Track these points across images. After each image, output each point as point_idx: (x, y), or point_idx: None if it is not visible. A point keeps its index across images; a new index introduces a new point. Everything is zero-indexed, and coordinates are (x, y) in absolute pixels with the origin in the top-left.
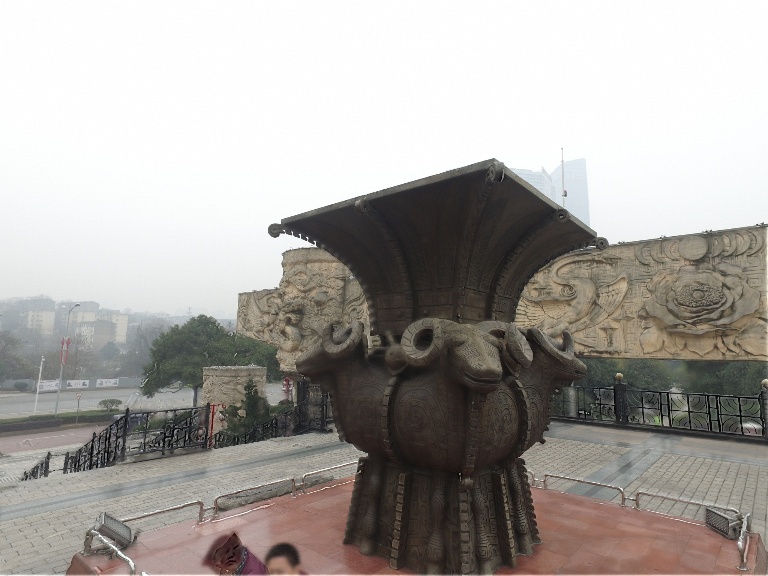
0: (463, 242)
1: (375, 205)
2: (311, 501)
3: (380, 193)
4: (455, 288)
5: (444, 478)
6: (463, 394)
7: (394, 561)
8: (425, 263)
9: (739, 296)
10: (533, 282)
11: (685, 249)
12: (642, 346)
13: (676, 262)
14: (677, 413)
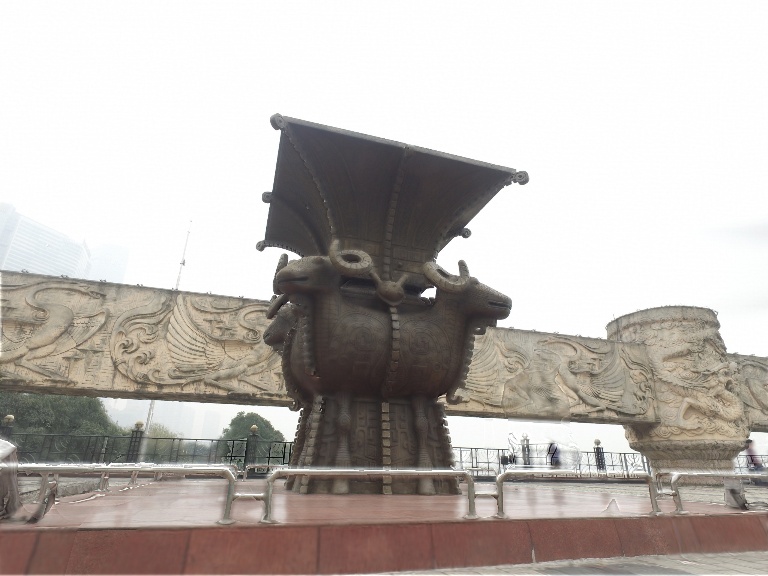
0: (451, 218)
1: (411, 157)
2: (152, 491)
3: (424, 150)
4: (429, 251)
5: (425, 402)
6: (466, 324)
7: (388, 487)
8: (409, 224)
9: None
10: (219, 321)
11: None
12: None
13: None
14: None
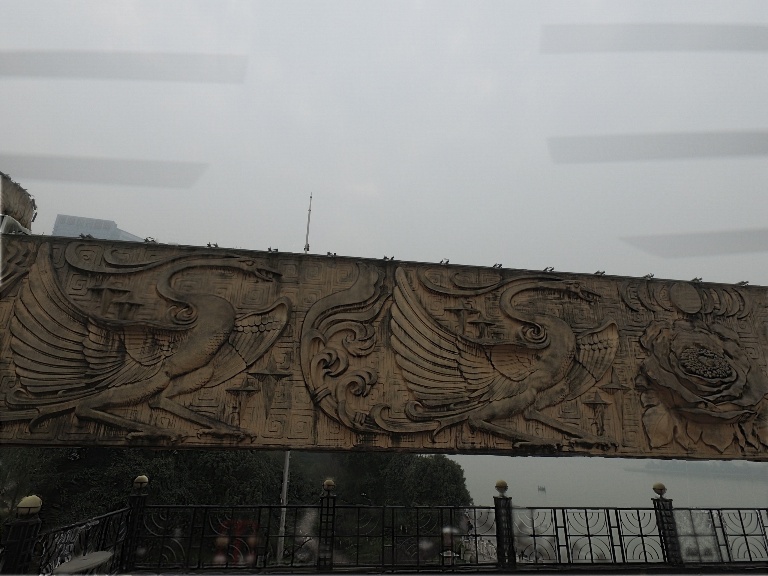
0: None
1: None
2: None
3: None
4: None
5: None
6: None
7: None
8: None
9: (748, 368)
10: (471, 310)
11: (679, 297)
12: (648, 435)
13: (669, 313)
14: (575, 539)
